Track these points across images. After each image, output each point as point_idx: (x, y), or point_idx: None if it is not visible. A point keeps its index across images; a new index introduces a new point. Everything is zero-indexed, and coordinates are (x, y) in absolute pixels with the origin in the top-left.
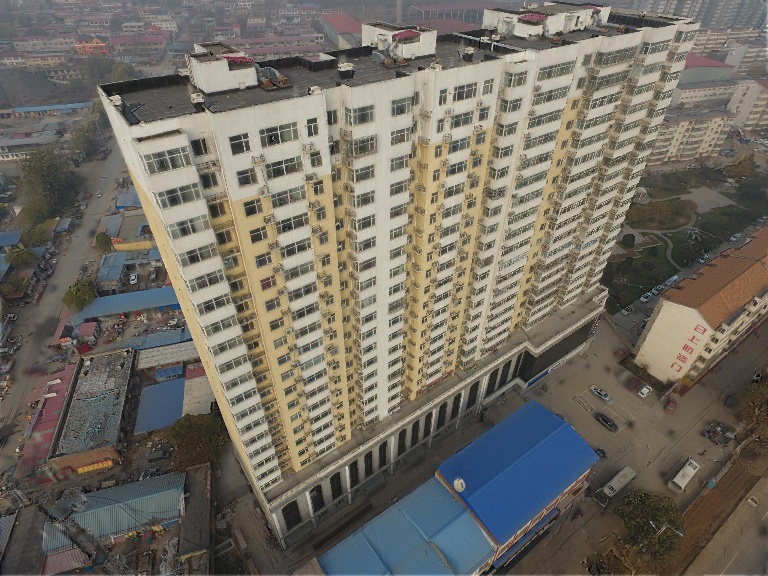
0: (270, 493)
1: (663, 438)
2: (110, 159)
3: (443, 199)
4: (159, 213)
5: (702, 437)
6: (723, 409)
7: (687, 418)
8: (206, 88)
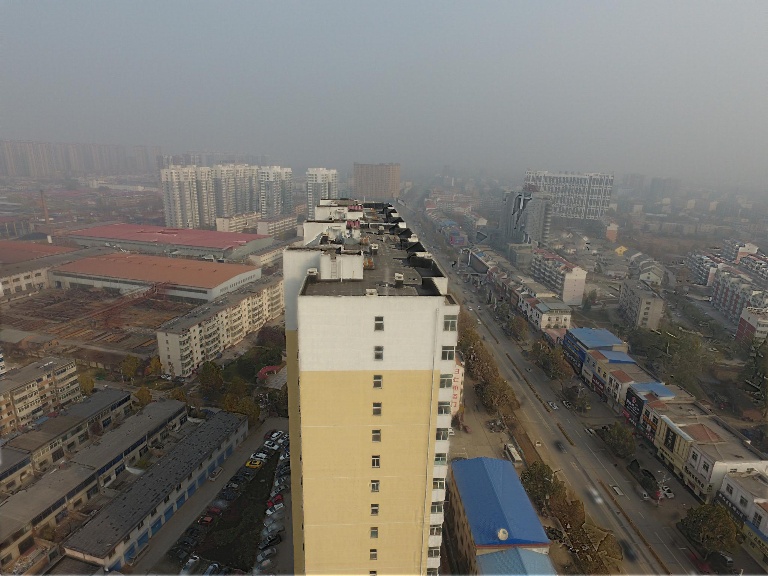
0: None
1: (484, 447)
2: None
3: None
4: (444, 368)
5: (493, 433)
6: (481, 414)
7: (478, 430)
8: (362, 275)
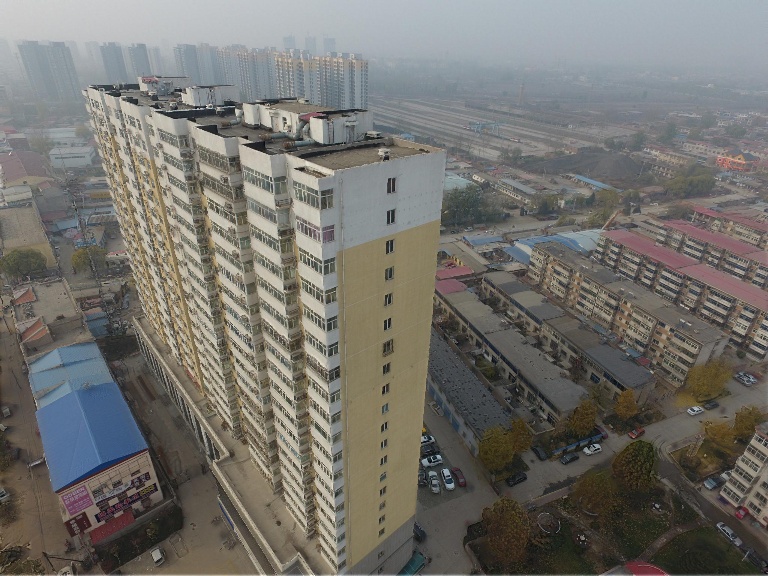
0: (144, 319)
1: None
2: (544, 222)
3: (147, 198)
4: None
5: None
6: None
7: None
8: None
